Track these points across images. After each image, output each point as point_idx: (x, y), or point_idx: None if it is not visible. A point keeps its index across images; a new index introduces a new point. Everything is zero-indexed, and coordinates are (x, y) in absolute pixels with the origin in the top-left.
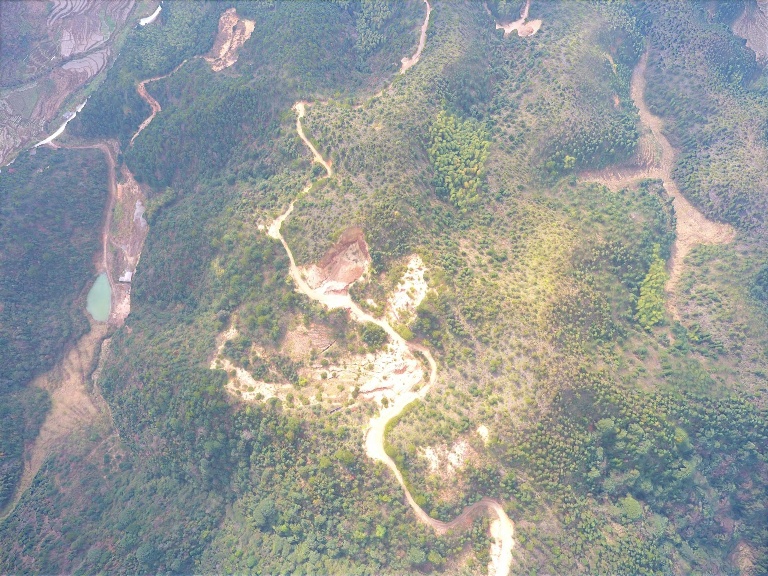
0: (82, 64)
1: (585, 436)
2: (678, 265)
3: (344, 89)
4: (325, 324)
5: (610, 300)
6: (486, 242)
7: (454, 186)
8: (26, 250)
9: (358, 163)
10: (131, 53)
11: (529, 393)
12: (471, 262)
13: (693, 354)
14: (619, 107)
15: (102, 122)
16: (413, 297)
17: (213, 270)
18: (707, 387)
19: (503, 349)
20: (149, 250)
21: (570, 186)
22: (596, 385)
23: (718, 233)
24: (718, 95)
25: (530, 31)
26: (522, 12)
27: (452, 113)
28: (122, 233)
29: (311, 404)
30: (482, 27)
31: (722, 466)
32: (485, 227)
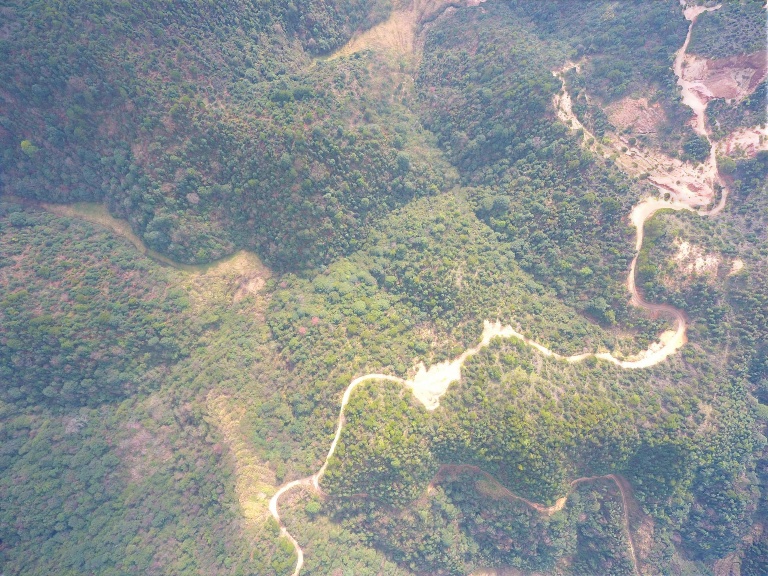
0: None
1: None
2: None
3: None
4: (667, 111)
5: None
6: None
7: None
8: None
9: None
10: None
11: None
12: None
13: None
14: None
15: None
16: (762, 143)
17: (602, 10)
18: None
19: None
20: None
21: None
22: None
23: None
24: None
25: None
26: None
27: None
28: None
29: (604, 157)
30: None
31: None
32: None
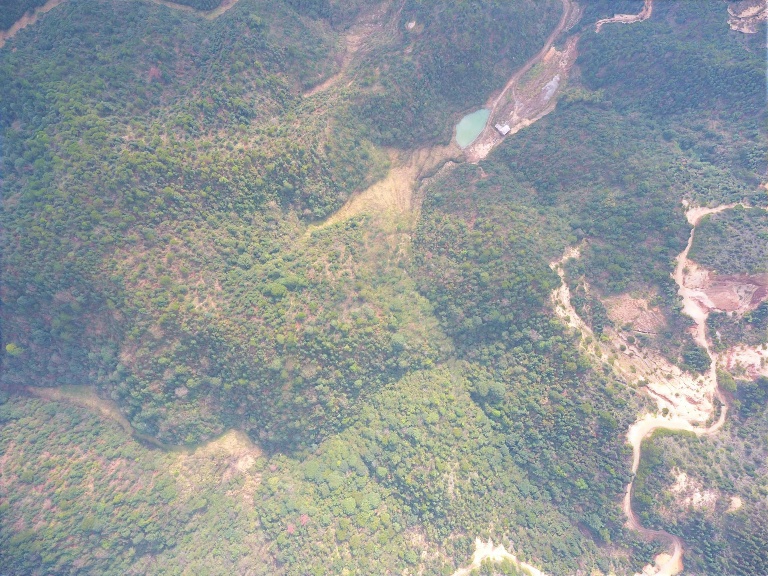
0: None
1: None
2: None
3: None
4: (667, 318)
5: None
6: None
7: None
8: (473, 48)
9: None
10: None
11: None
12: None
13: None
14: None
15: None
16: (763, 365)
17: (603, 195)
18: None
19: None
20: (548, 127)
21: None
22: None
23: None
24: None
25: None
26: None
27: None
28: (526, 90)
29: (602, 359)
30: None
31: None
32: None
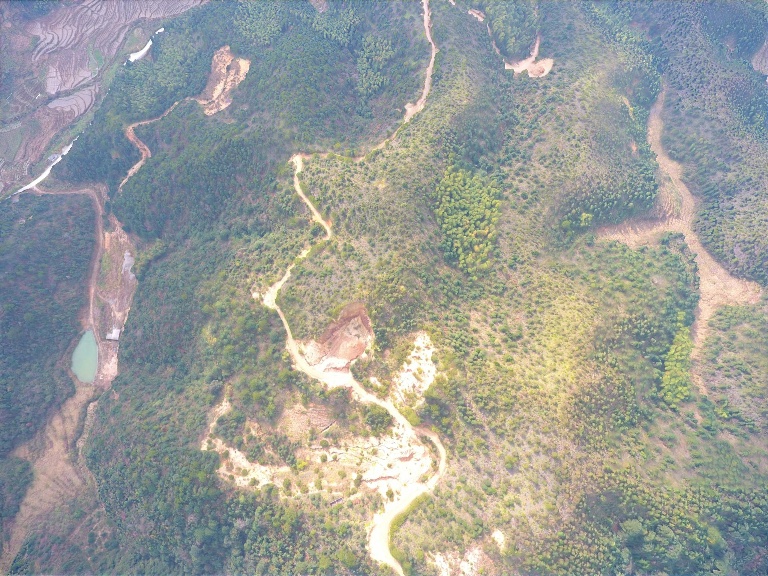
0: (69, 102)
1: (610, 539)
2: (702, 328)
3: (344, 138)
4: (325, 404)
5: (634, 381)
6: (499, 316)
7: (463, 249)
8: (6, 311)
9: (360, 225)
10: (119, 94)
11: (549, 497)
12: (483, 341)
13: (722, 433)
14: (636, 154)
15: (89, 166)
16: (420, 379)
17: (205, 337)
18: (740, 475)
19: (520, 444)
20: (137, 308)
21: (587, 246)
22: (622, 485)
23: (744, 291)
24: (741, 141)
25: (541, 71)
26: (532, 49)
27: (460, 167)
28: (110, 286)
29: (310, 492)
30: (490, 68)
31: (755, 559)
32: (497, 298)
